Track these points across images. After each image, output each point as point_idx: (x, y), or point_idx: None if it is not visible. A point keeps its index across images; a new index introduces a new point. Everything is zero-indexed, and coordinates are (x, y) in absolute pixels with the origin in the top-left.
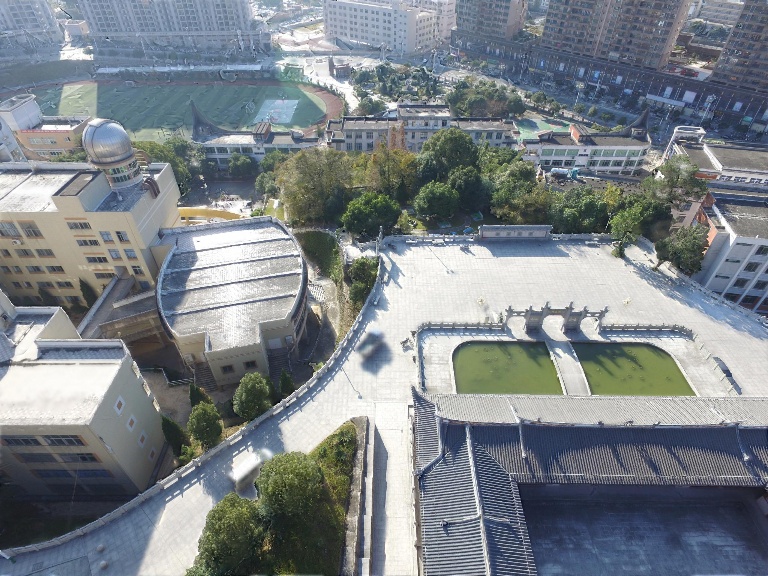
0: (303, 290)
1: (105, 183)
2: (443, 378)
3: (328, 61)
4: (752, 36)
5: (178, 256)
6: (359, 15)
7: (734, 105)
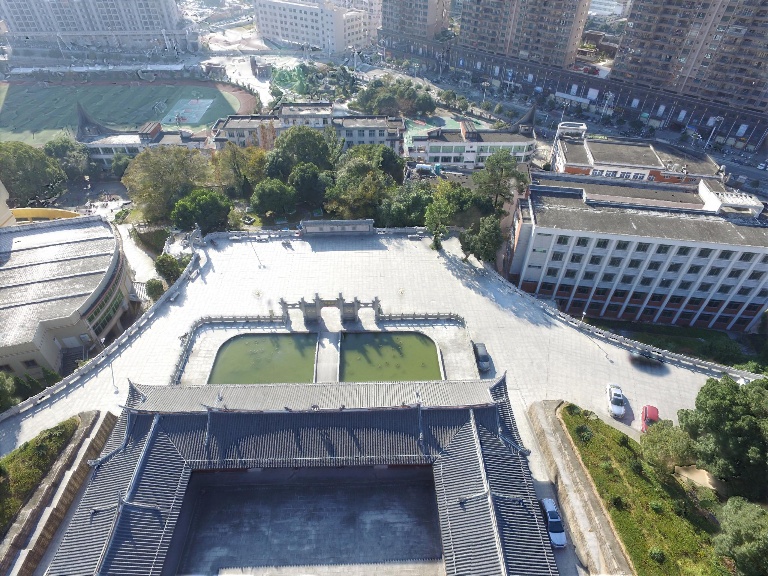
0: (106, 288)
1: None
2: (202, 371)
3: (250, 60)
4: (642, 35)
5: None
6: (288, 14)
7: (632, 102)
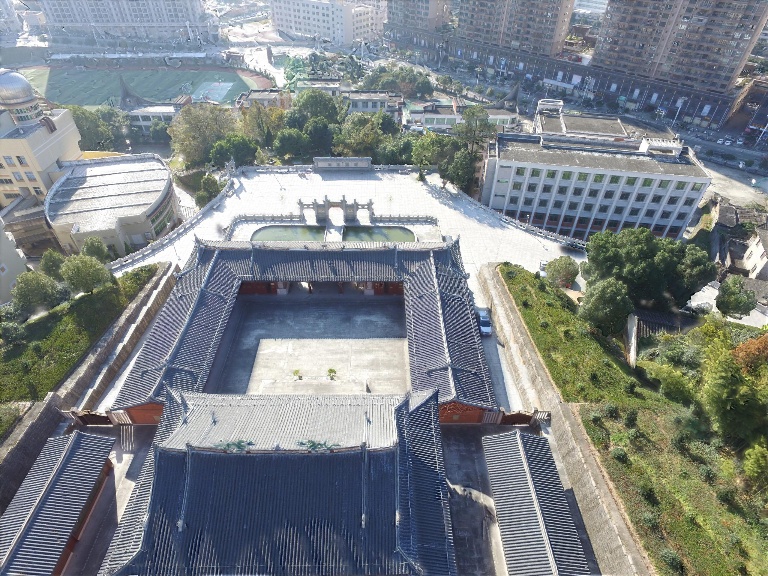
0: (163, 201)
1: (10, 120)
2: None
3: (266, 49)
4: (618, 25)
5: (71, 180)
6: (301, 9)
7: (611, 86)
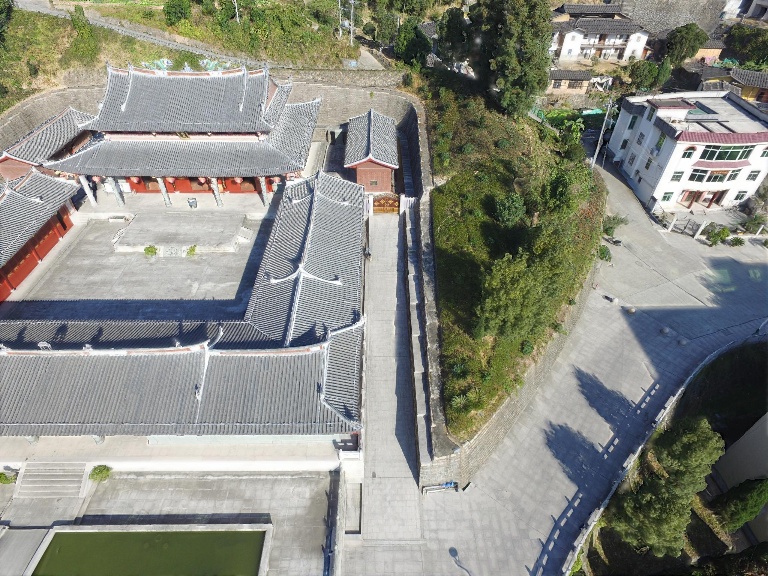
0: None
1: None
2: None
3: None
4: None
5: None
6: None
7: None
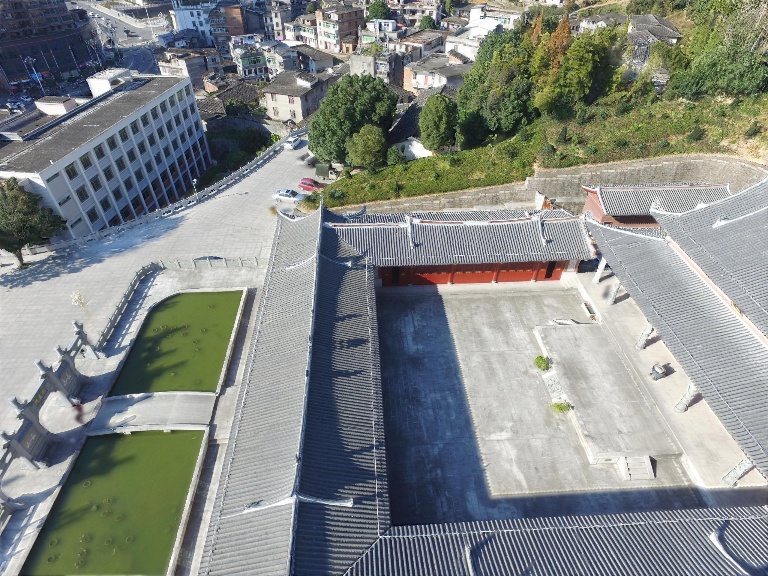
0: None
1: None
2: None
3: None
4: None
5: None
6: None
7: None
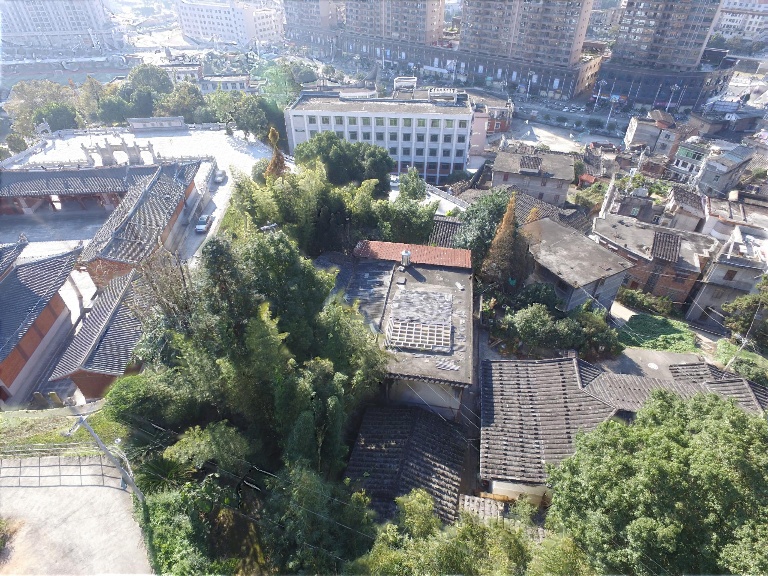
0: None
1: None
2: None
3: (165, 51)
4: (475, 11)
5: None
6: (206, 15)
7: (478, 68)
